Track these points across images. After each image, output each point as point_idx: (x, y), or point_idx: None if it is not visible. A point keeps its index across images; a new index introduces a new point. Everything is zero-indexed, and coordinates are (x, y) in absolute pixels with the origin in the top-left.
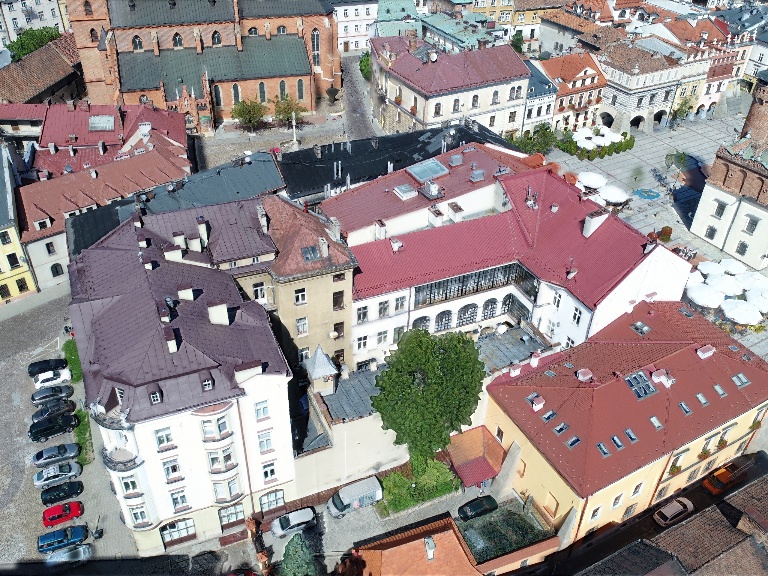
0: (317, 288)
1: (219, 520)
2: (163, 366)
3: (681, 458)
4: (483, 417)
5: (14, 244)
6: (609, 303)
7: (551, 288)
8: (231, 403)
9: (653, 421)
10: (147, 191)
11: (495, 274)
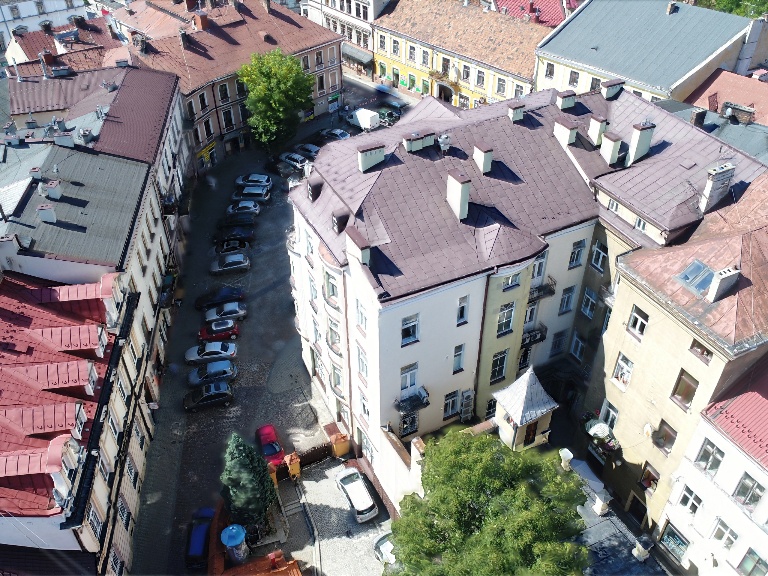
0: (663, 333)
1: (337, 402)
2: (341, 172)
3: None
4: None
5: None
6: None
7: None
8: None
9: None
10: (742, 108)
11: None
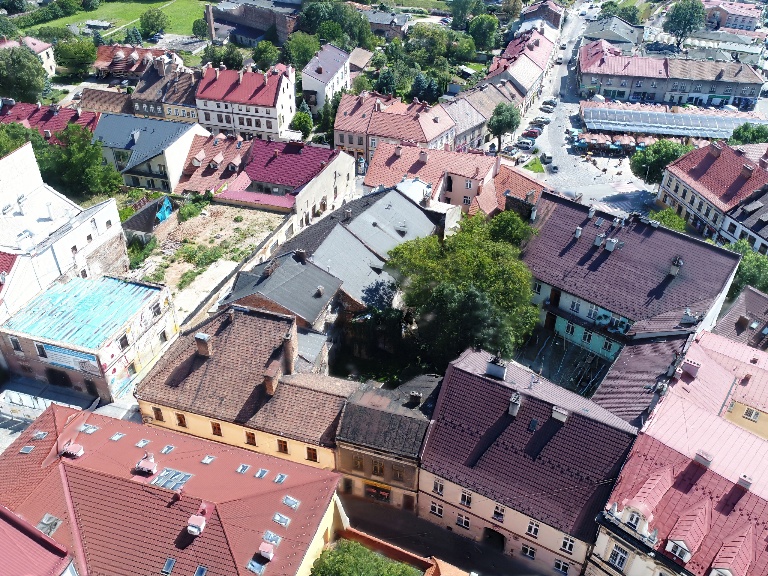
0: None
1: None
2: None
3: None
4: None
5: None
6: None
7: None
8: None
9: (208, 462)
10: None
11: None
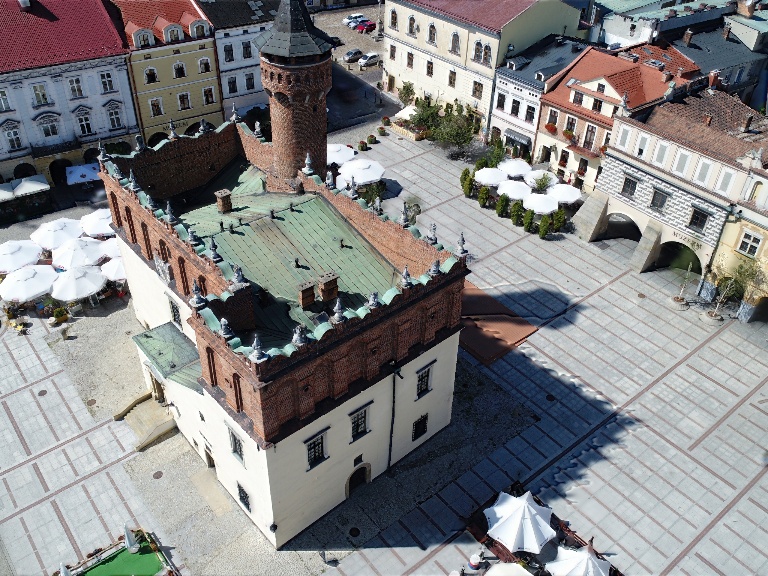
0: None
1: None
2: None
3: None
4: None
5: None
6: None
7: None
8: None
9: None
10: None
11: None
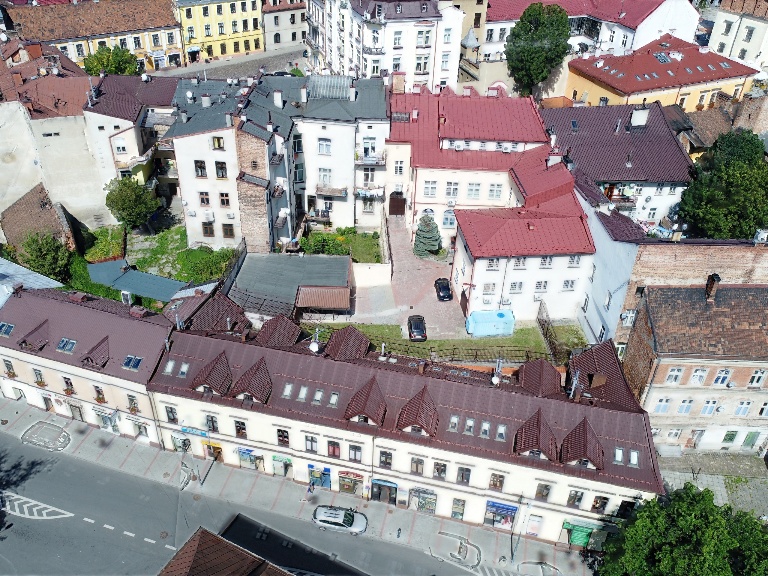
0: (467, 7)
1: None
2: None
3: (685, 101)
4: (564, 90)
5: (258, 12)
6: (645, 27)
7: (608, 29)
8: (434, 23)
9: (669, 72)
10: None
11: (572, 24)
